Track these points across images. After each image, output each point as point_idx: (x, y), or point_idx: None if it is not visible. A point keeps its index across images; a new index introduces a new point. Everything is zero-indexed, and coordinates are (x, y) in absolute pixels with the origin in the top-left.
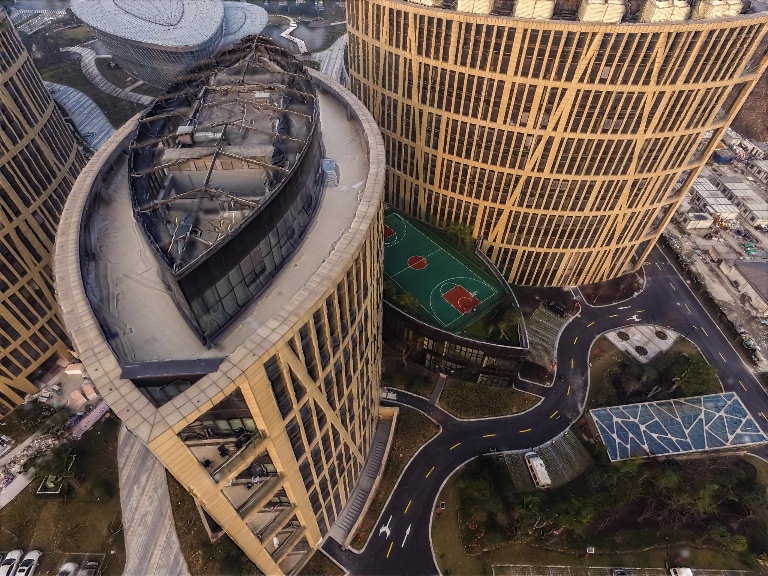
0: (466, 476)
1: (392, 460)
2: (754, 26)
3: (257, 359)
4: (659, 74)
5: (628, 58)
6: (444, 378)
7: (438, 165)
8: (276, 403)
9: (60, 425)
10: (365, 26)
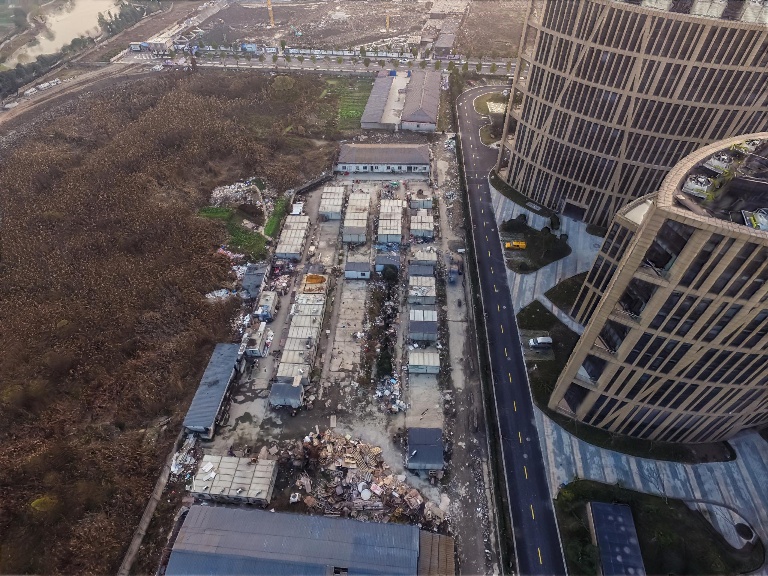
0: None
1: None
2: None
3: None
4: None
5: None
6: None
7: None
8: None
9: None
10: None
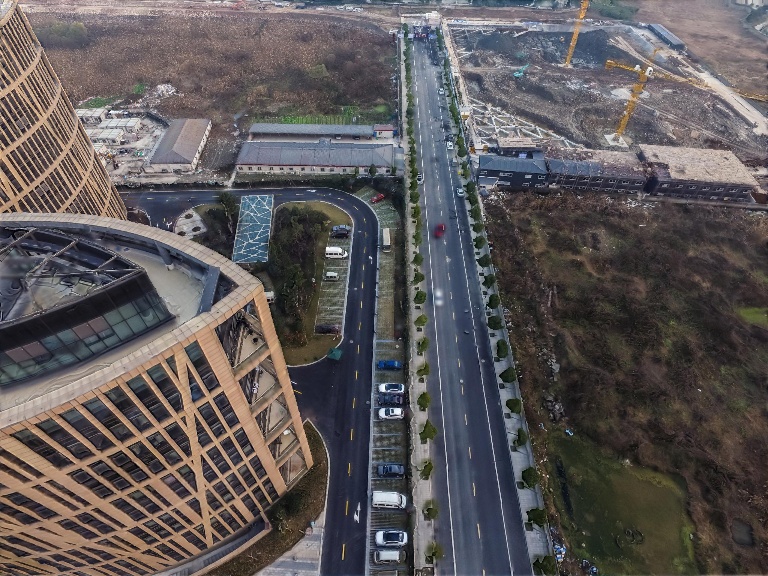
0: None
1: None
2: (12, 17)
3: None
4: (7, 73)
5: None
6: None
7: None
8: None
9: None
10: None
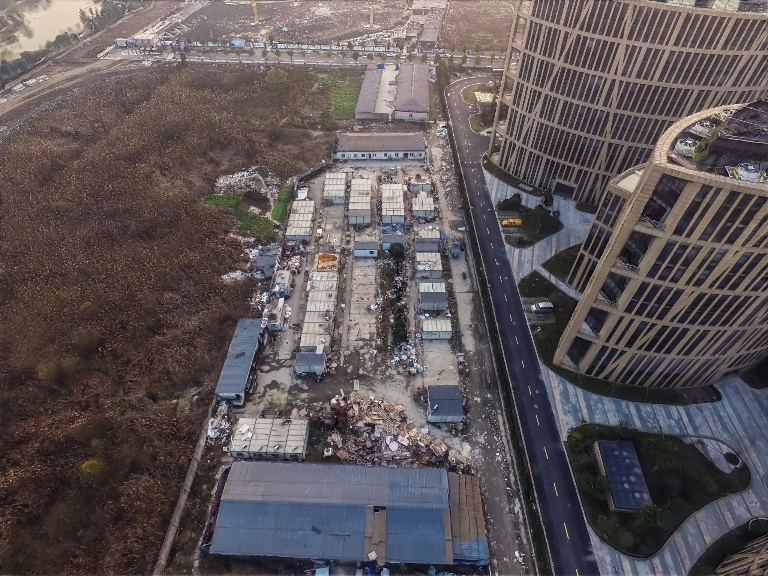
0: None
1: None
2: None
3: None
4: None
5: None
6: None
7: None
8: None
9: None
10: None
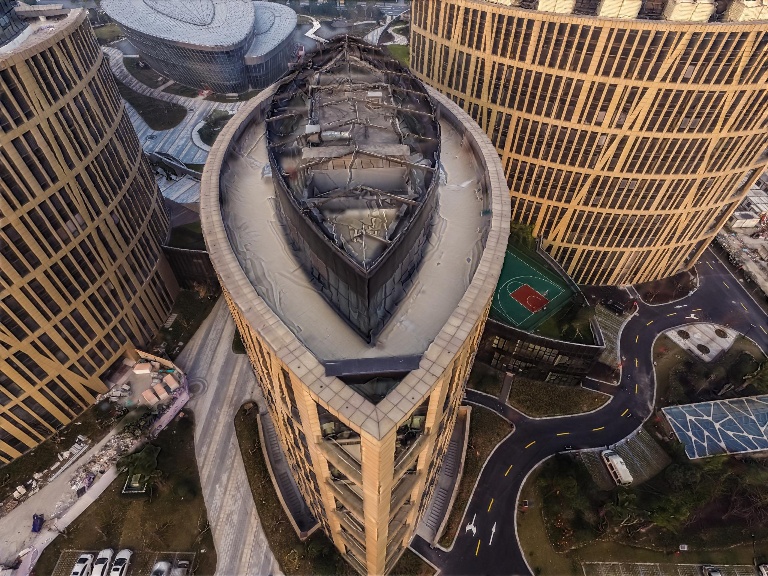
0: (547, 474)
1: (470, 458)
2: None
3: (454, 356)
4: (742, 73)
5: (714, 57)
6: (511, 377)
7: (503, 164)
8: (445, 400)
9: (135, 424)
10: (435, 25)
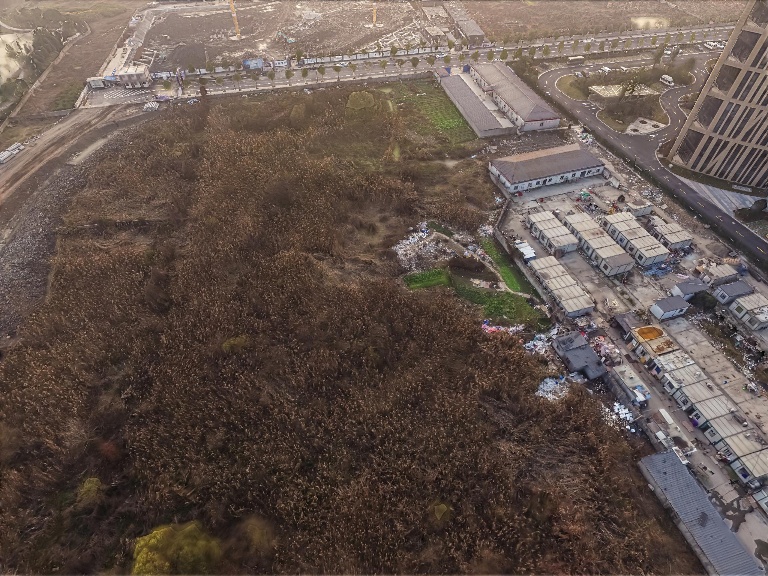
0: None
1: None
2: None
3: None
4: None
5: None
6: None
7: None
8: None
9: None
10: None
